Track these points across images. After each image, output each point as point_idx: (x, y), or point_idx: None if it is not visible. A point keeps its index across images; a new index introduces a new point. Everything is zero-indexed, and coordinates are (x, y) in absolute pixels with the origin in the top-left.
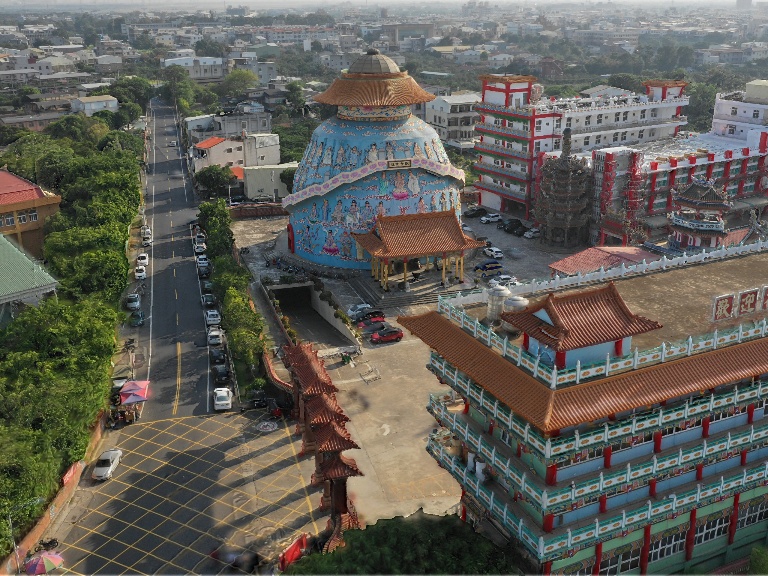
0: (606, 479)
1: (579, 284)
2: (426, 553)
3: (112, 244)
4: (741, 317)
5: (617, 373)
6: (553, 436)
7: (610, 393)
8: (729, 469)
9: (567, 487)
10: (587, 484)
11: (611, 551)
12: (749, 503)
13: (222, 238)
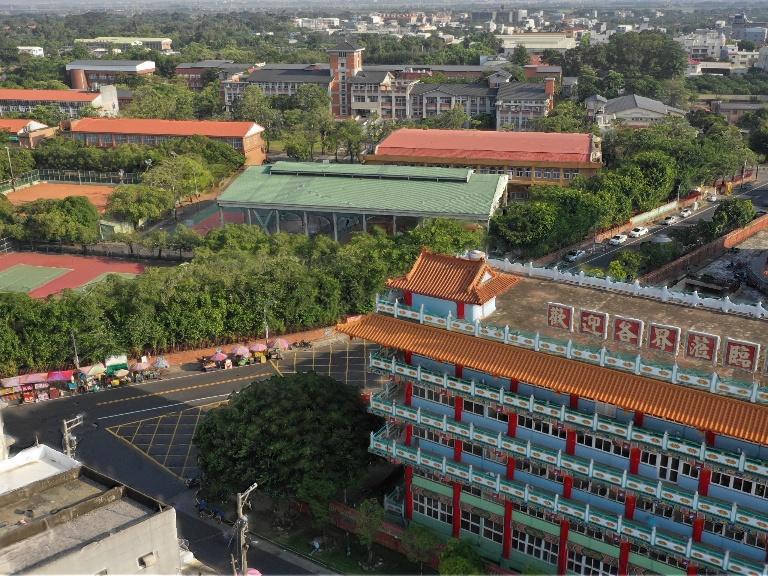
0: (424, 415)
1: (607, 289)
2: (300, 392)
3: (573, 203)
4: (639, 353)
5: (431, 325)
6: (408, 364)
7: (410, 334)
8: (606, 510)
9: (390, 402)
10: (407, 409)
11: (469, 505)
12: (643, 571)
13: (688, 227)
